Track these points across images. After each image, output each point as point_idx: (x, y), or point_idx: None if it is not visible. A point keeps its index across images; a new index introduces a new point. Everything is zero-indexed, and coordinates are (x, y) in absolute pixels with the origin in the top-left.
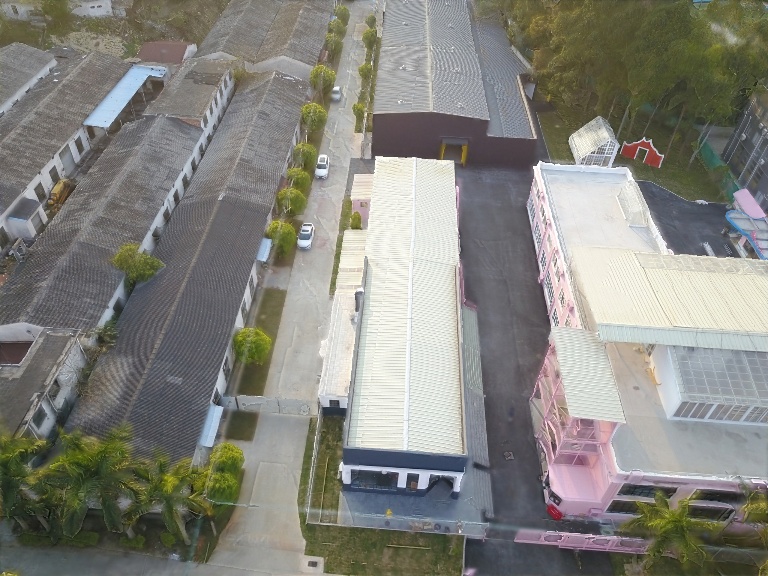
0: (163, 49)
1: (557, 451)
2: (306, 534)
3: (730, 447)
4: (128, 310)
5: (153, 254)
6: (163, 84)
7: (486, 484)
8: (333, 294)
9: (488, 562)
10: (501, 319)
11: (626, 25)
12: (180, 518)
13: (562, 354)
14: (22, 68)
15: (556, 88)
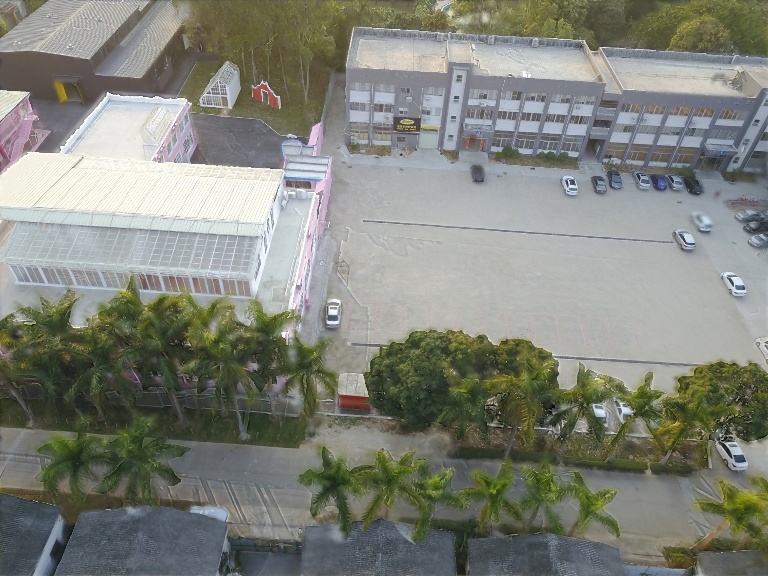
0: None
1: None
2: None
3: None
4: None
5: None
6: None
7: None
8: None
9: None
10: None
11: None
12: None
13: None
14: None
15: None
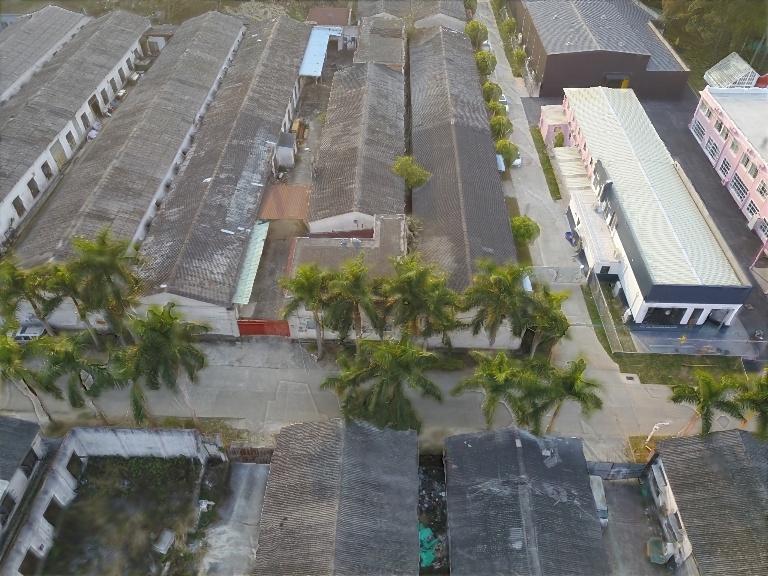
0: (329, 13)
1: None
2: (616, 360)
3: None
4: (418, 207)
5: None
6: (337, 43)
7: (740, 325)
8: (556, 199)
9: None
10: None
11: None
12: (539, 339)
13: None
14: (225, 32)
15: (694, 29)
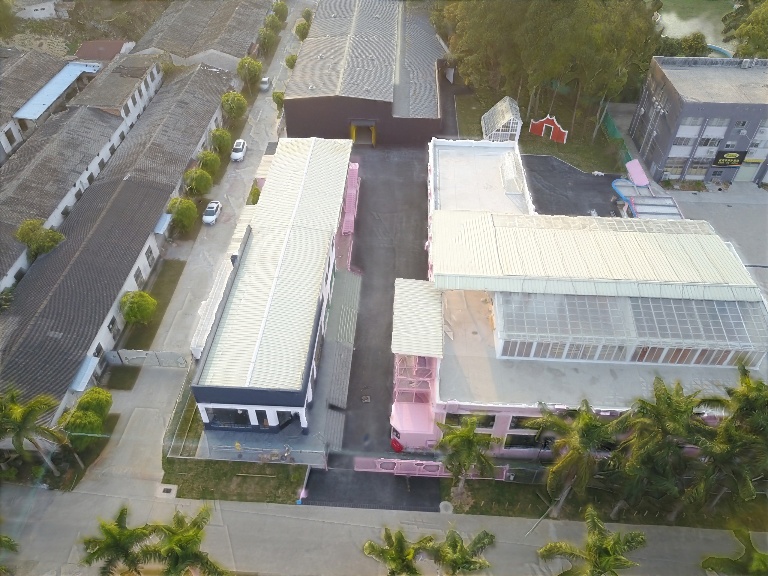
0: (101, 47)
1: (395, 389)
2: (166, 466)
3: (548, 381)
4: (26, 278)
5: (58, 229)
6: None
7: (339, 423)
8: None
9: (327, 487)
10: (383, 282)
11: (516, 7)
12: (42, 448)
13: (399, 301)
14: None
15: (466, 71)
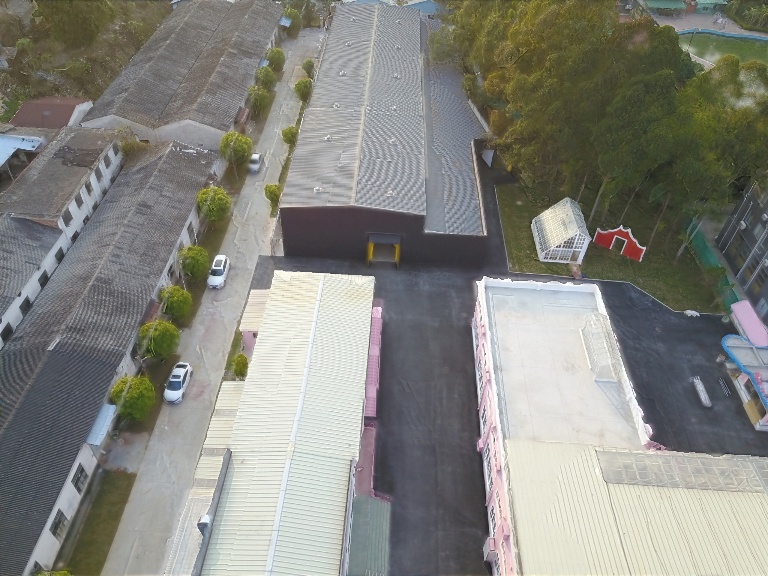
0: (45, 110)
1: None
2: None
3: None
4: None
5: None
6: None
7: None
8: None
9: None
10: (422, 514)
11: (595, 98)
12: None
13: None
14: None
15: (515, 163)
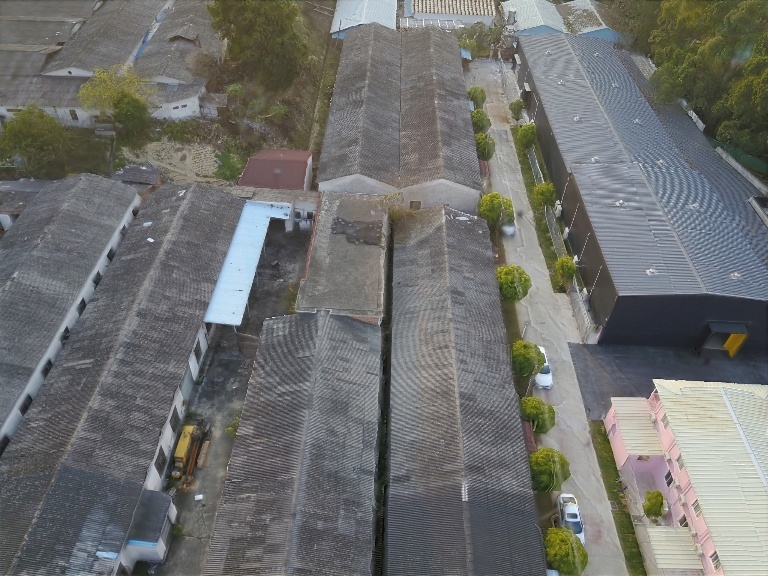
0: (276, 168)
1: None
2: None
3: None
4: None
5: None
6: (284, 223)
7: None
8: None
9: None
10: None
11: None
12: None
13: None
14: (99, 218)
15: None
